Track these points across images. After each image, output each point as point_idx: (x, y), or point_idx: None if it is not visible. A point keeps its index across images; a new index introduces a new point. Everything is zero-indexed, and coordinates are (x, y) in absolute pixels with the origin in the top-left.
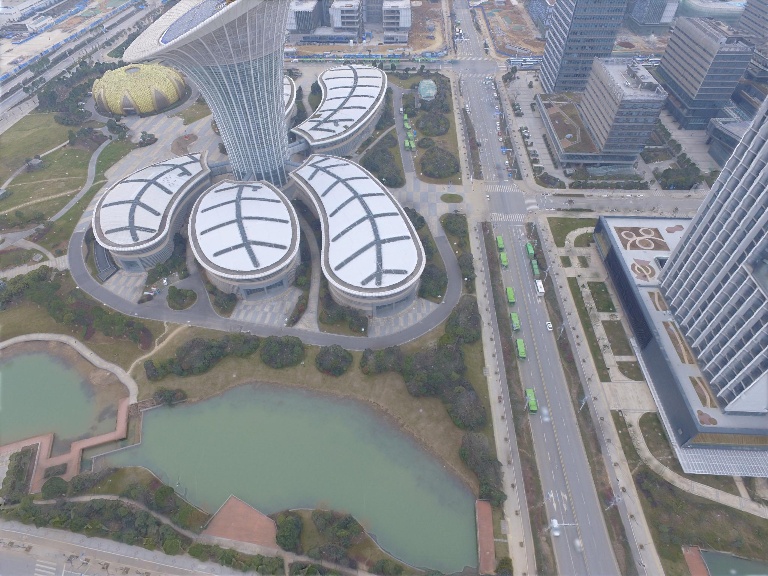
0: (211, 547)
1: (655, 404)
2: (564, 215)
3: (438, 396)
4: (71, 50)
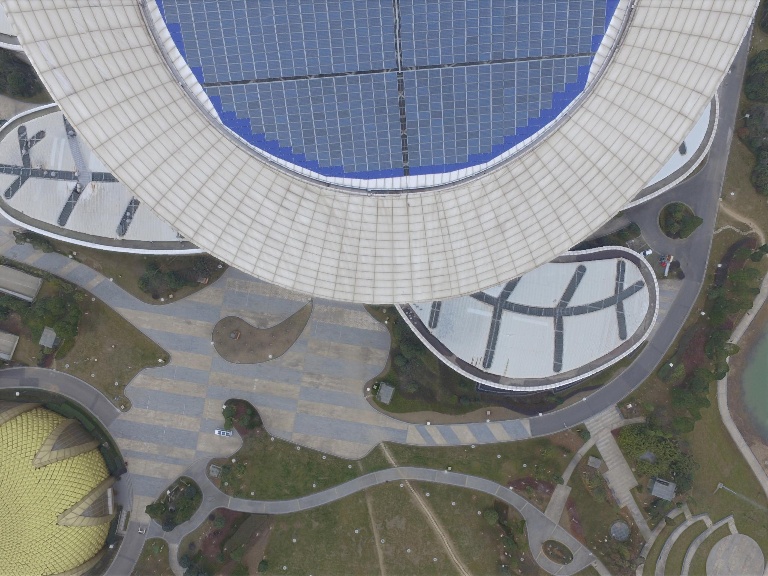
0: None
1: None
2: None
3: None
4: None
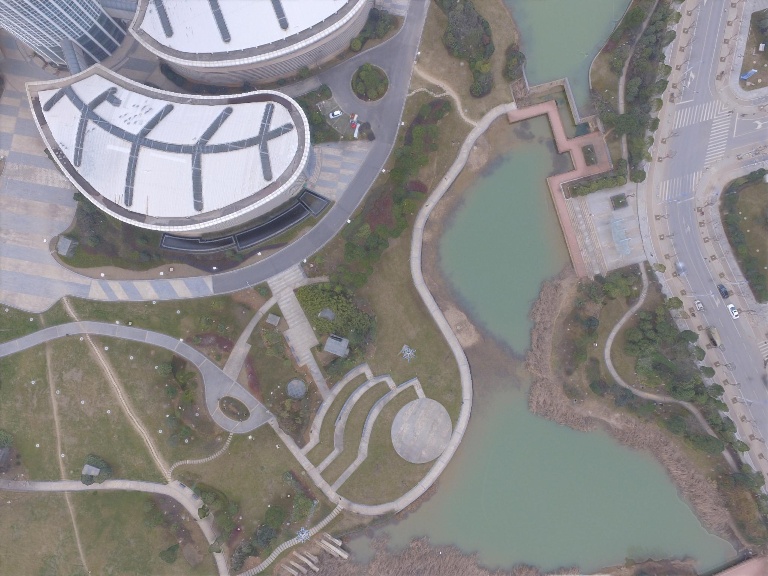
0: None
1: None
2: None
3: None
4: None
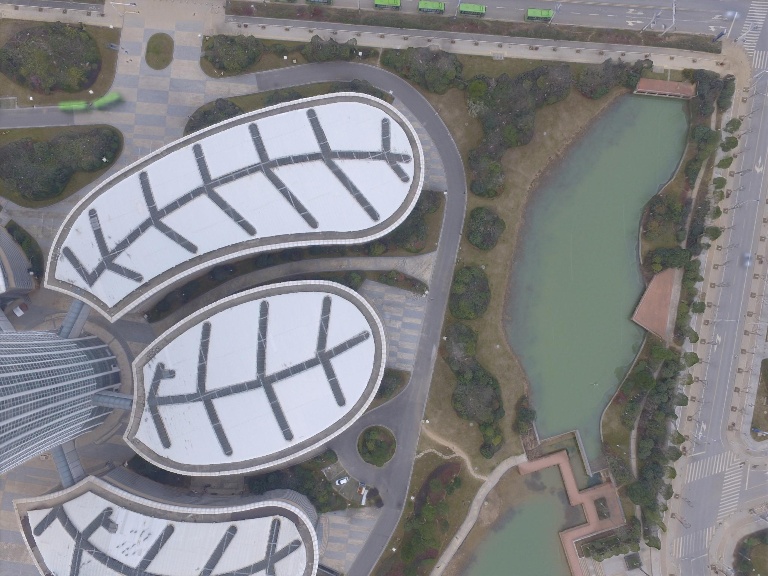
0: (684, 325)
1: None
2: None
3: (535, 112)
4: None
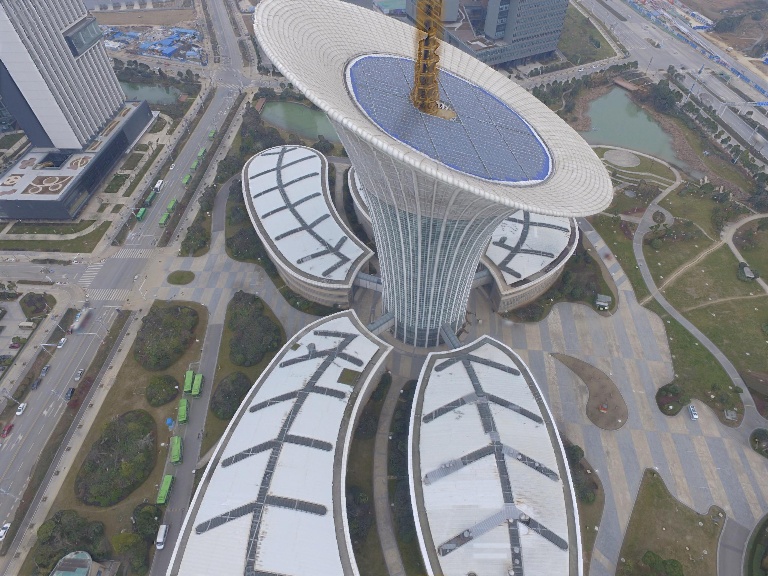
0: None
1: (145, 135)
2: (70, 255)
3: None
4: None
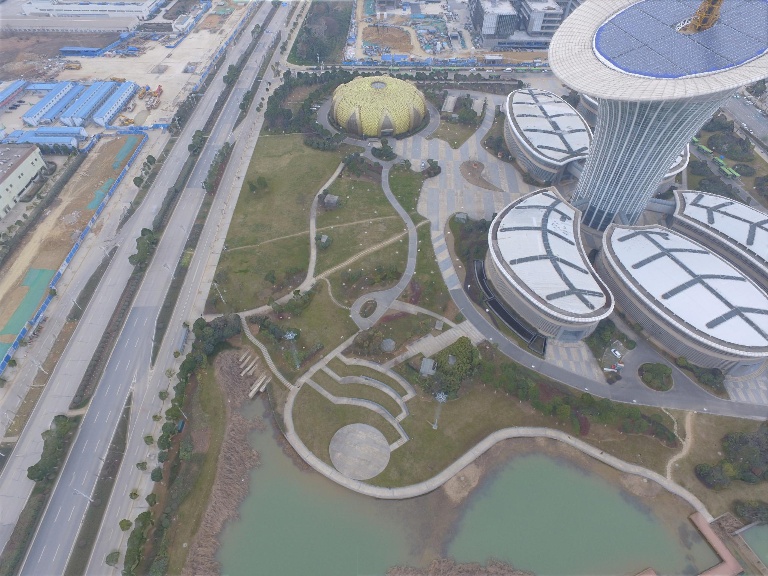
0: None
1: None
2: None
3: None
4: (245, 56)
